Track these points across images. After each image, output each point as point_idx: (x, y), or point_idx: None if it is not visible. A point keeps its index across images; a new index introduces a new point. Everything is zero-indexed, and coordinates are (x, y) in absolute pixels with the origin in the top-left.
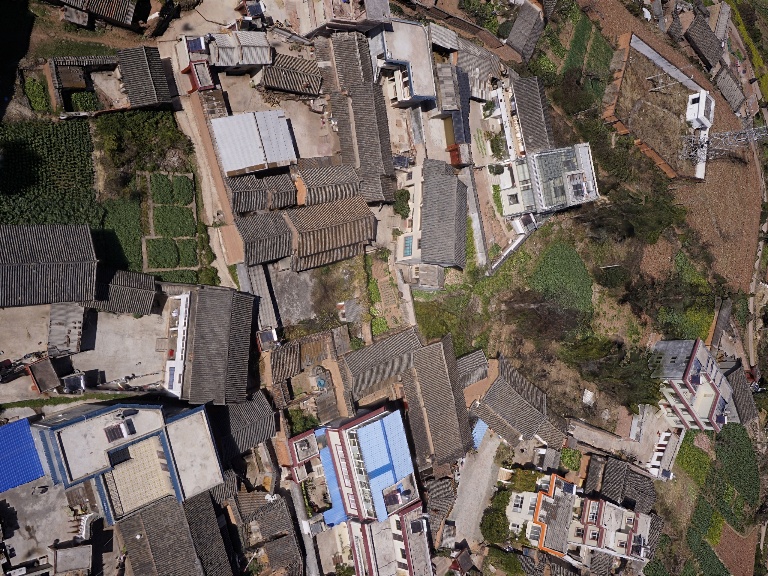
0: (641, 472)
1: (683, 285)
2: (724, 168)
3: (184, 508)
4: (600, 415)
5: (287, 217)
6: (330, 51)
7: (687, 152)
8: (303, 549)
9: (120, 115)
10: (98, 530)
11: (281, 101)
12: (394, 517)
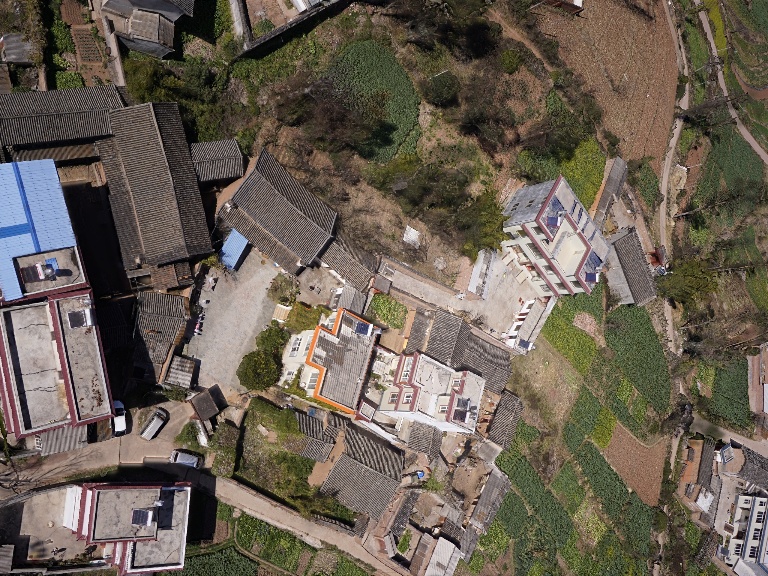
0: (492, 341)
1: None
2: (617, 11)
3: None
4: (432, 263)
5: None
6: None
7: None
8: None
9: None
10: None
11: None
12: None
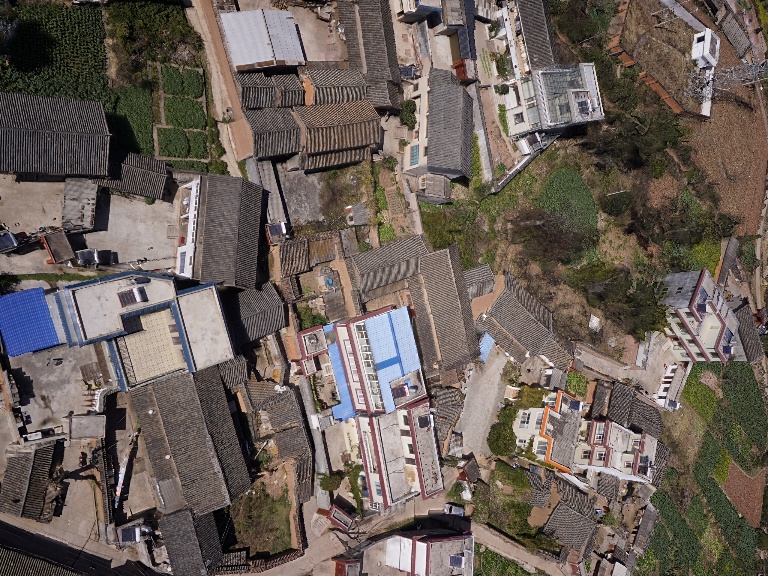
0: (648, 402)
1: None
2: (730, 110)
3: (195, 385)
4: (606, 342)
5: (295, 113)
6: None
7: (692, 90)
8: (312, 445)
9: (132, 5)
10: (111, 407)
11: (289, 7)
12: (402, 413)
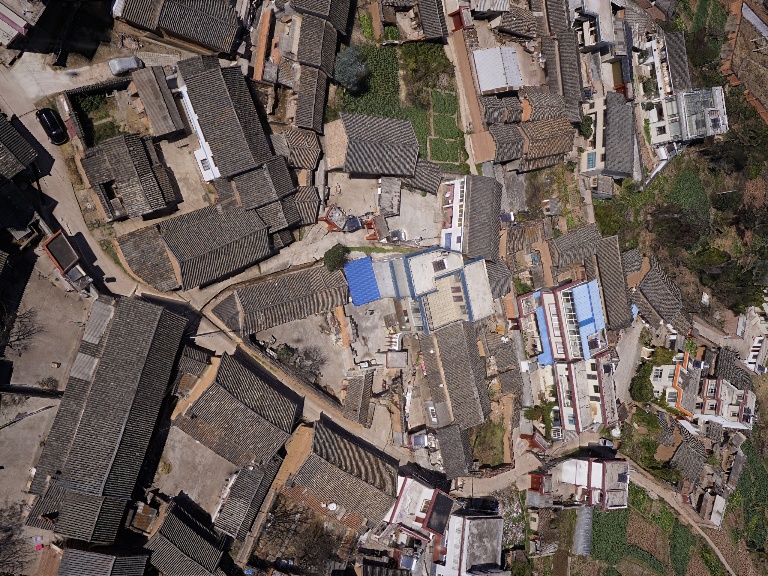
0: (741, 366)
1: None
2: None
3: (464, 332)
4: (712, 315)
5: (521, 128)
6: (542, 4)
7: None
8: None
9: (415, 45)
10: None
11: (506, 42)
12: (590, 361)
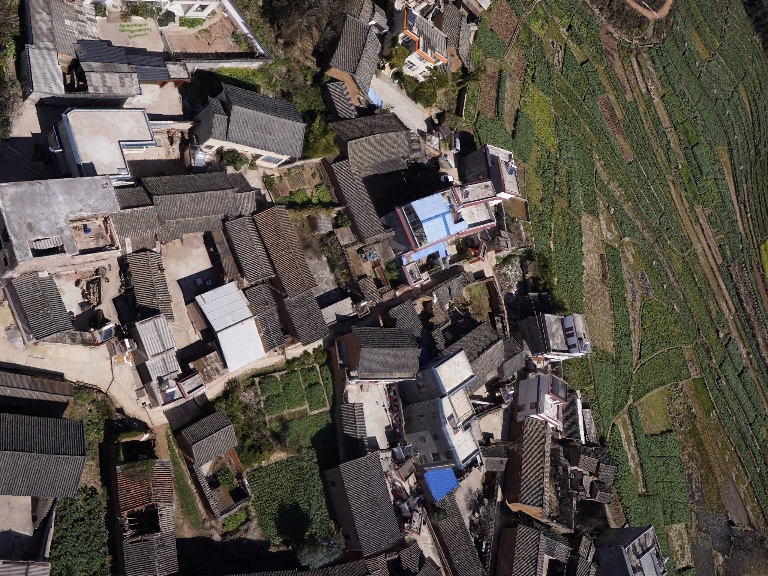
0: None
1: None
2: None
3: None
4: None
5: None
6: None
7: None
8: None
9: None
10: None
11: None
12: None
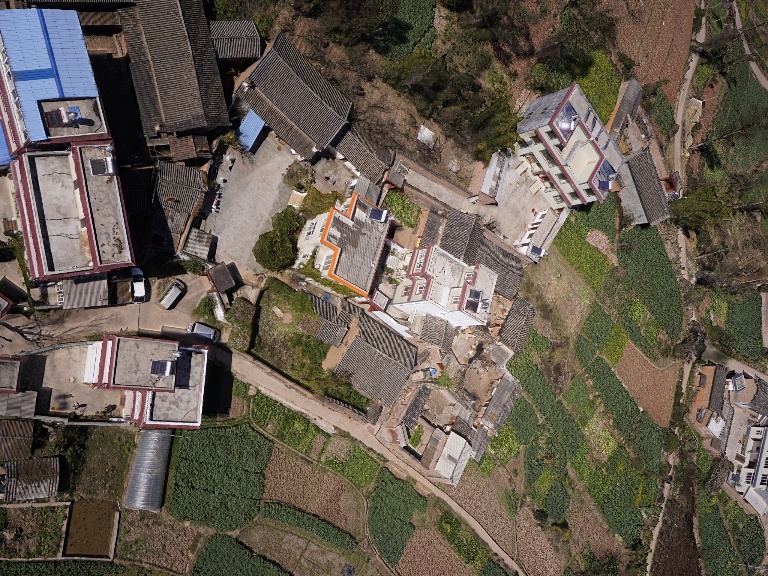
0: (505, 247)
1: (572, 48)
2: None
3: None
4: (446, 165)
5: None
6: None
7: None
8: None
9: None
10: None
11: None
12: None
